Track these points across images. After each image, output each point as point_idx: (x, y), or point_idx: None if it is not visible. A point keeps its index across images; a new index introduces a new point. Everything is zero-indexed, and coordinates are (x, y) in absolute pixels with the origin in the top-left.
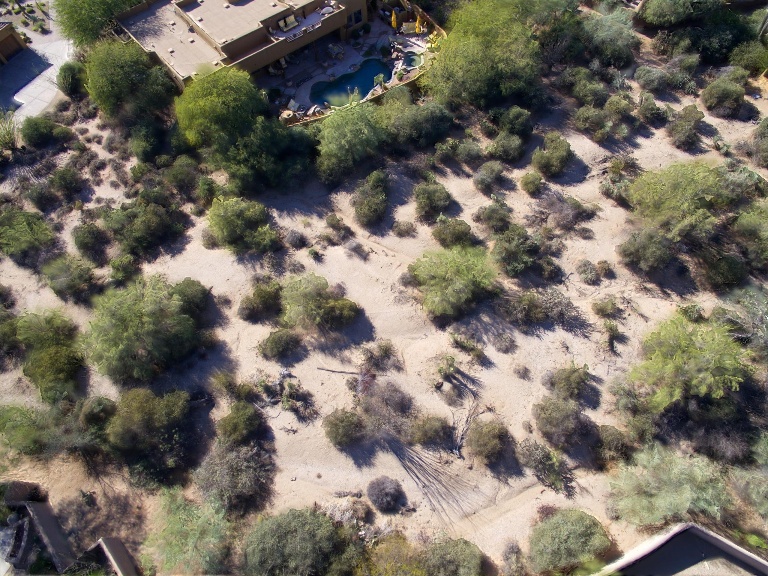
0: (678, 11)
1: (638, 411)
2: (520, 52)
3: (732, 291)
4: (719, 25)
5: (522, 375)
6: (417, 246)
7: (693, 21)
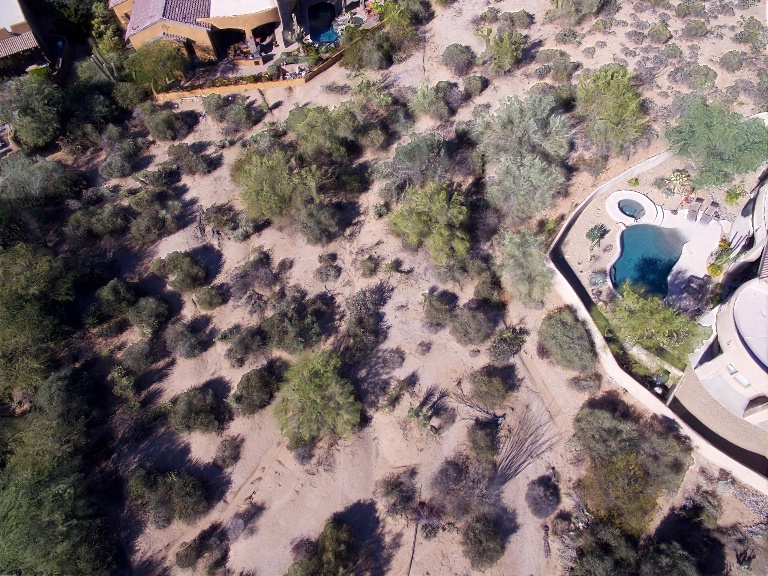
0: (50, 118)
1: (463, 267)
2: (25, 265)
3: (362, 182)
4: (83, 99)
5: (427, 349)
6: (257, 438)
7: (66, 114)
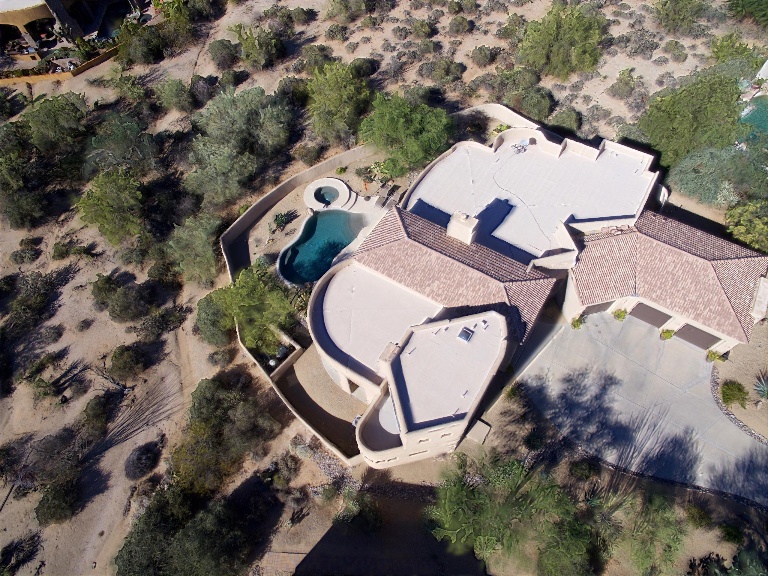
0: None
1: (146, 250)
2: None
3: (94, 171)
4: None
5: (87, 326)
6: None
7: None
